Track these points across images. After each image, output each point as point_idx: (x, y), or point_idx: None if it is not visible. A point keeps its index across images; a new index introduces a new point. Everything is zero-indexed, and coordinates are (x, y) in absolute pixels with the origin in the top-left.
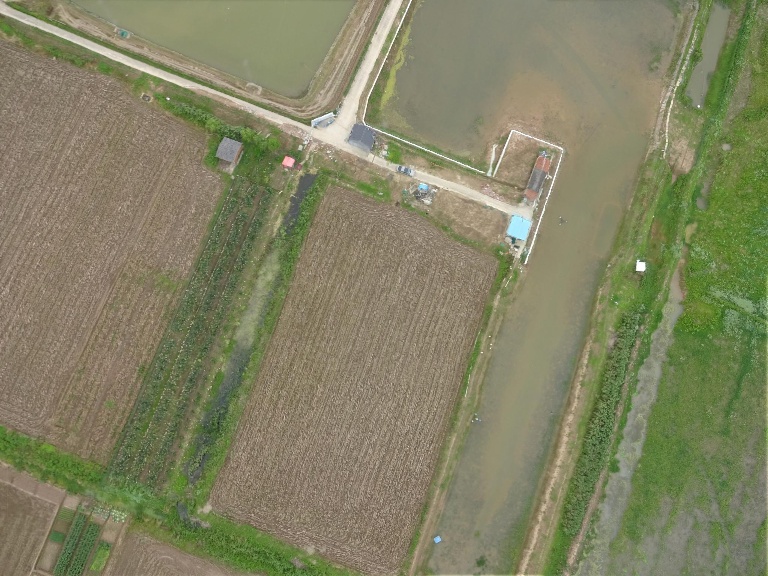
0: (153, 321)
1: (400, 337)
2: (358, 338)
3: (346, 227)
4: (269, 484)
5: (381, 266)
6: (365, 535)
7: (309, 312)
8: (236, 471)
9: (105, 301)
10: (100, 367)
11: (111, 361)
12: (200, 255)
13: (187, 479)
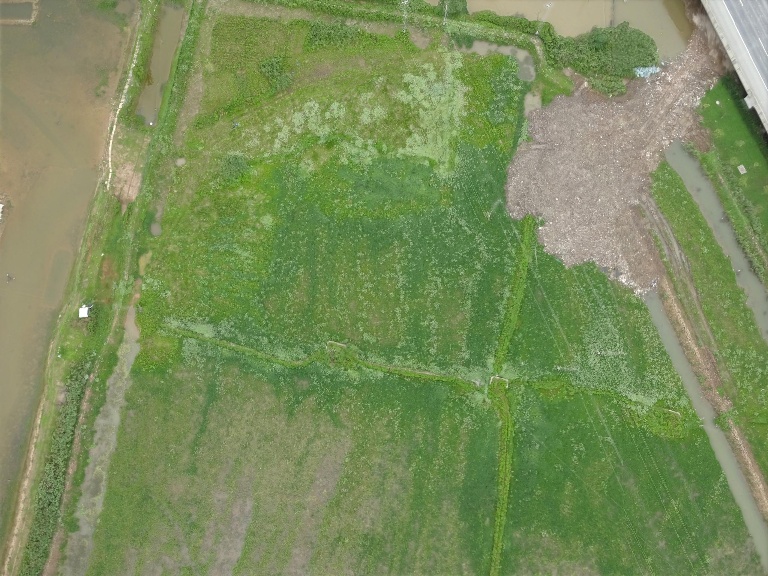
0: None
1: None
2: None
3: None
4: None
5: None
6: None
7: None
8: None
9: None
10: None
11: None
12: None
13: None
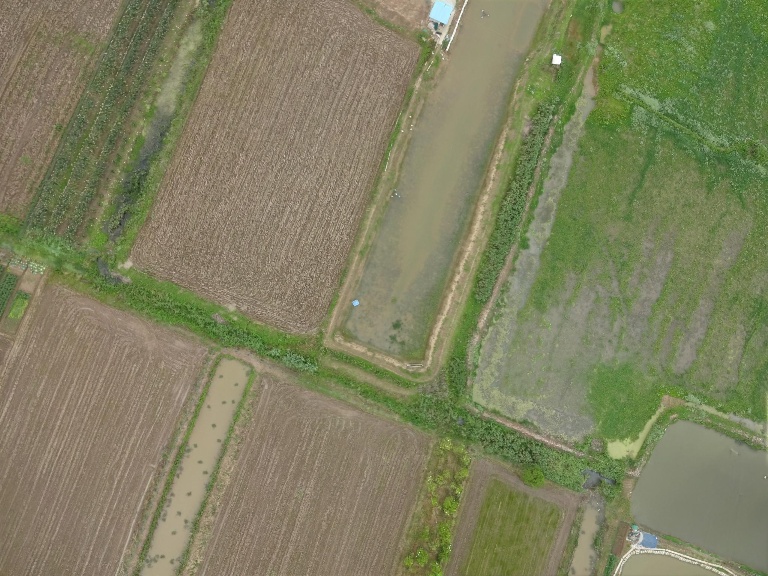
0: (70, 81)
1: (323, 113)
2: (281, 111)
3: (270, 3)
4: (191, 244)
5: (305, 44)
6: (286, 296)
7: (232, 83)
8: (157, 231)
9: (19, 58)
10: (15, 123)
11: (26, 118)
12: (119, 19)
13: (107, 236)
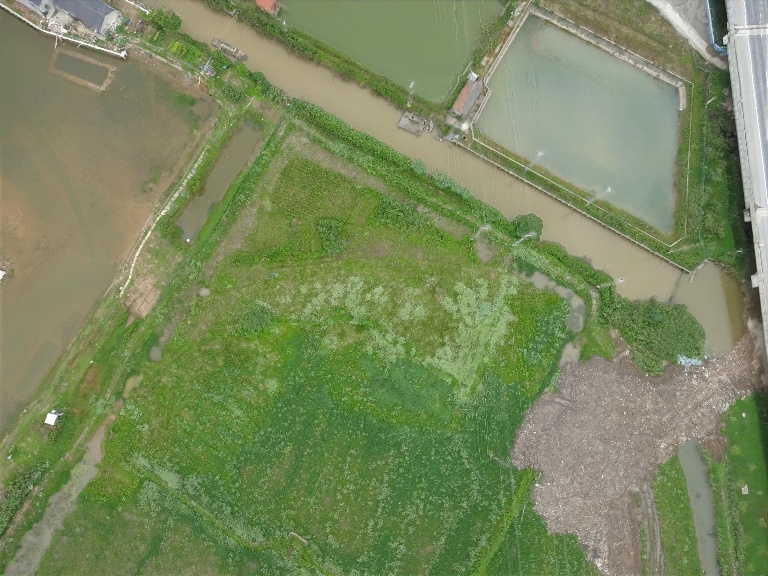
0: None
1: None
2: None
3: None
4: None
5: None
6: None
7: None
8: None
9: None
10: None
11: None
12: None
13: None
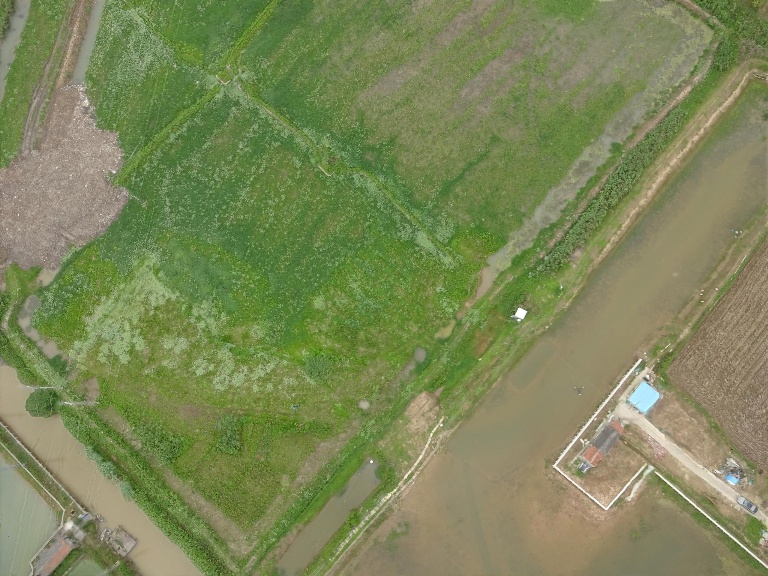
0: None
1: None
2: None
3: None
4: None
5: None
6: None
7: None
8: None
9: None
10: None
11: None
12: None
13: None
